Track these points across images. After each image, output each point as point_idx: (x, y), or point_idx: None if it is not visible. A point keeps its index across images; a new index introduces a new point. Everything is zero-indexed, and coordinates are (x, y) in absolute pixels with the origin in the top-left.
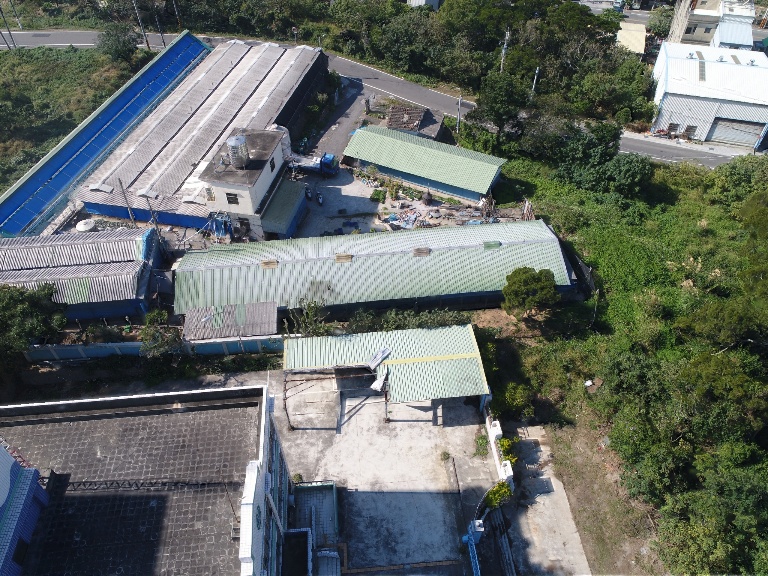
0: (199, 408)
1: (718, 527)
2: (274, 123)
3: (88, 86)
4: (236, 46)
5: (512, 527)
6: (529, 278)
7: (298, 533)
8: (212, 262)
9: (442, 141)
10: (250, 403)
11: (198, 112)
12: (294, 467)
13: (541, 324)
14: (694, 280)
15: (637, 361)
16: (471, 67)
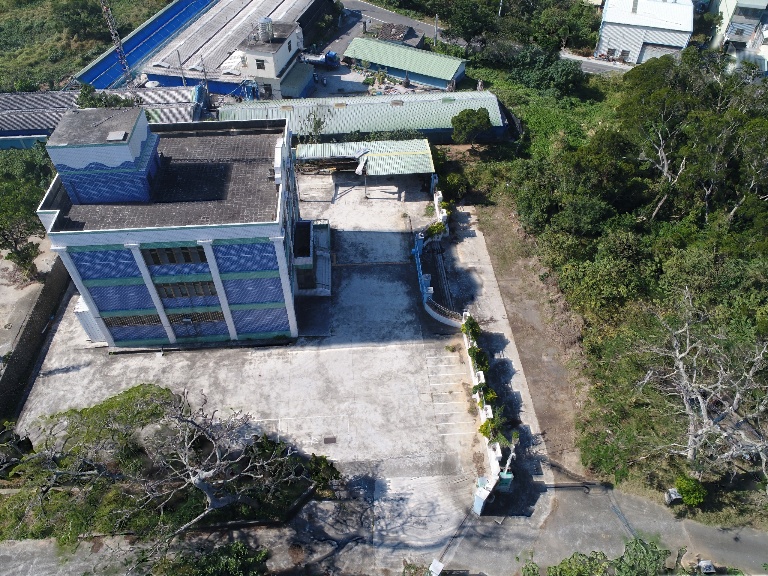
0: (247, 132)
1: None
2: None
3: (143, 6)
4: None
5: (446, 252)
6: (470, 113)
7: (305, 224)
8: (245, 107)
9: None
10: (278, 130)
11: (231, 22)
12: (302, 219)
13: None
14: None
15: None
16: (449, 2)
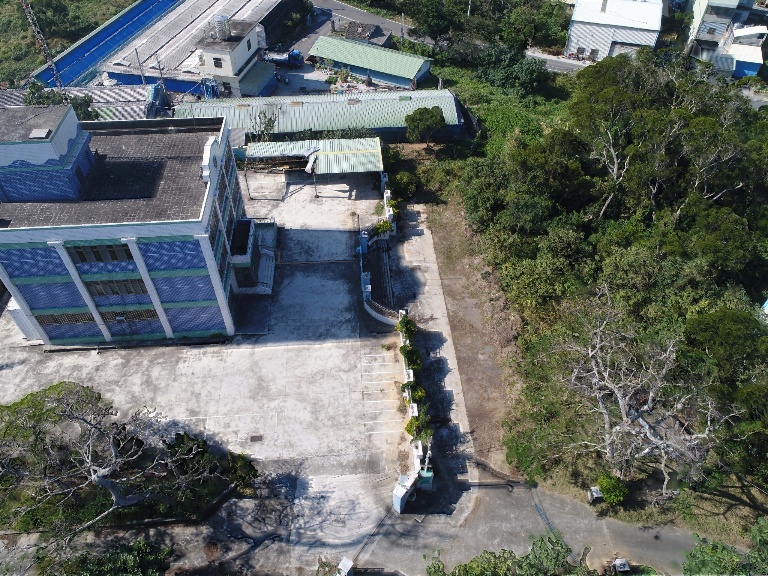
0: (185, 130)
1: (521, 241)
2: None
3: (111, 4)
4: None
5: (392, 250)
6: (424, 111)
7: (245, 222)
8: (201, 105)
9: None
10: (216, 128)
11: (197, 20)
12: (250, 217)
13: None
14: None
15: None
16: None
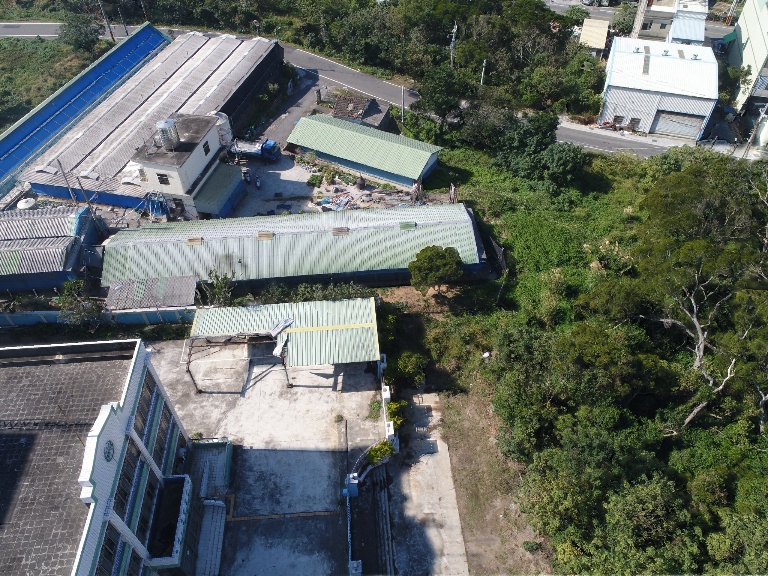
0: (79, 360)
1: (579, 483)
2: (215, 110)
3: (49, 75)
4: (195, 38)
5: (393, 483)
6: (434, 255)
7: (177, 479)
8: (141, 239)
9: (385, 130)
10: (126, 356)
11: (149, 100)
12: (196, 426)
13: (450, 300)
14: (608, 262)
15: (528, 333)
16: (423, 60)
